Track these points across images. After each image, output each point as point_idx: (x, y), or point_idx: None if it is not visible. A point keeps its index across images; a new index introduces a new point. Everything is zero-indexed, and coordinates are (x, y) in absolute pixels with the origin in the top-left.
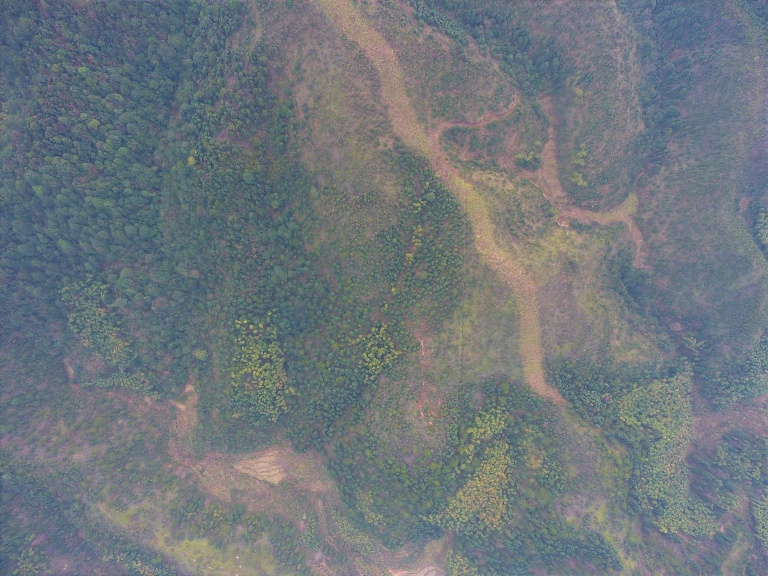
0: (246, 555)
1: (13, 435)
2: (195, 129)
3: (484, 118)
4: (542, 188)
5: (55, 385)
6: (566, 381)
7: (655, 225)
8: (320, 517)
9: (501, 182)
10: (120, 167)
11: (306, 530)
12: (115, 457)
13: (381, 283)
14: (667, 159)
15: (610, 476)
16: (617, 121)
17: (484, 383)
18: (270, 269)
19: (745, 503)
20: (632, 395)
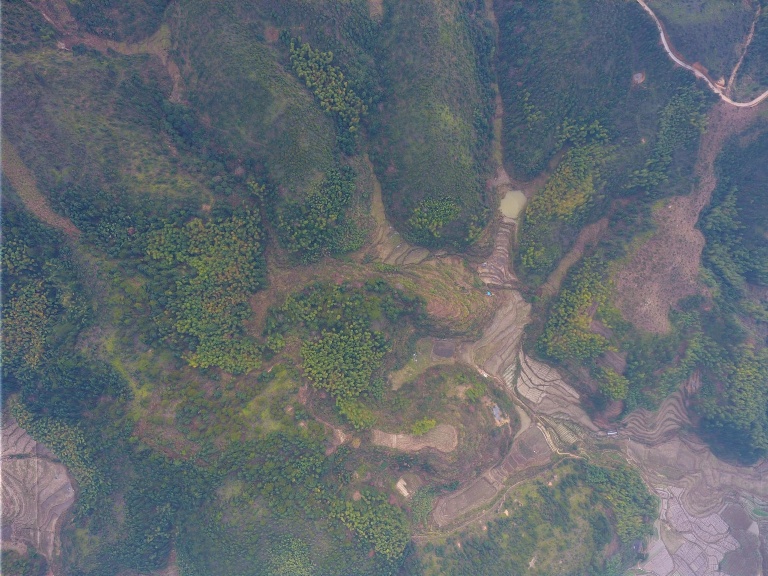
0: None
1: None
2: None
3: None
4: (45, 11)
5: None
6: (79, 211)
7: (181, 55)
8: None
9: None
10: None
11: None
12: None
13: None
14: None
15: (115, 304)
16: None
17: None
18: None
19: (297, 344)
20: (164, 231)
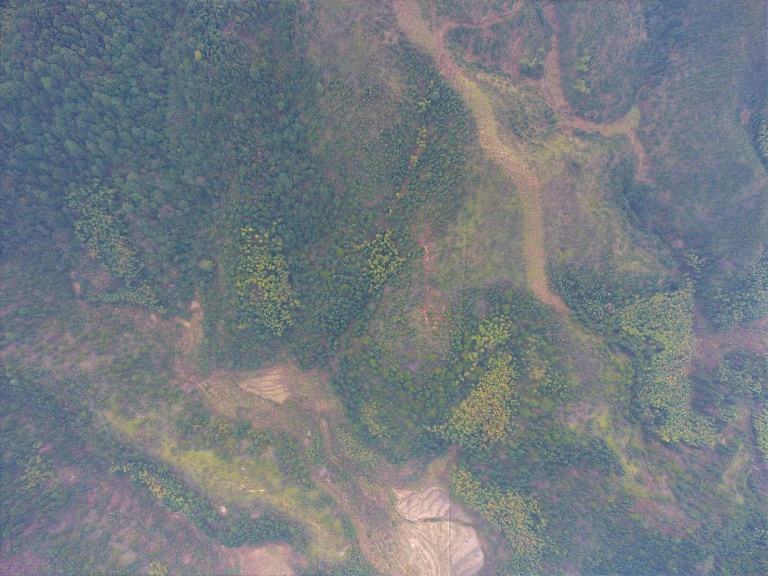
0: (251, 467)
1: (21, 343)
2: (202, 23)
3: (488, 18)
4: (545, 97)
5: (62, 299)
6: (569, 289)
7: (657, 137)
8: (324, 435)
9: (505, 85)
10: (127, 64)
11: (311, 446)
12: (122, 367)
13: (386, 187)
14: (669, 70)
15: (613, 381)
16: (620, 25)
17: (488, 290)
18: (275, 177)
19: (746, 416)
20: (634, 306)
